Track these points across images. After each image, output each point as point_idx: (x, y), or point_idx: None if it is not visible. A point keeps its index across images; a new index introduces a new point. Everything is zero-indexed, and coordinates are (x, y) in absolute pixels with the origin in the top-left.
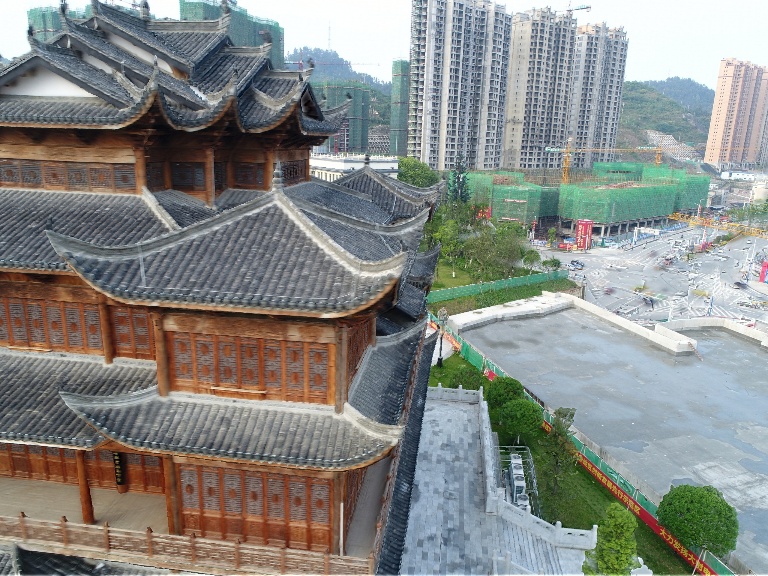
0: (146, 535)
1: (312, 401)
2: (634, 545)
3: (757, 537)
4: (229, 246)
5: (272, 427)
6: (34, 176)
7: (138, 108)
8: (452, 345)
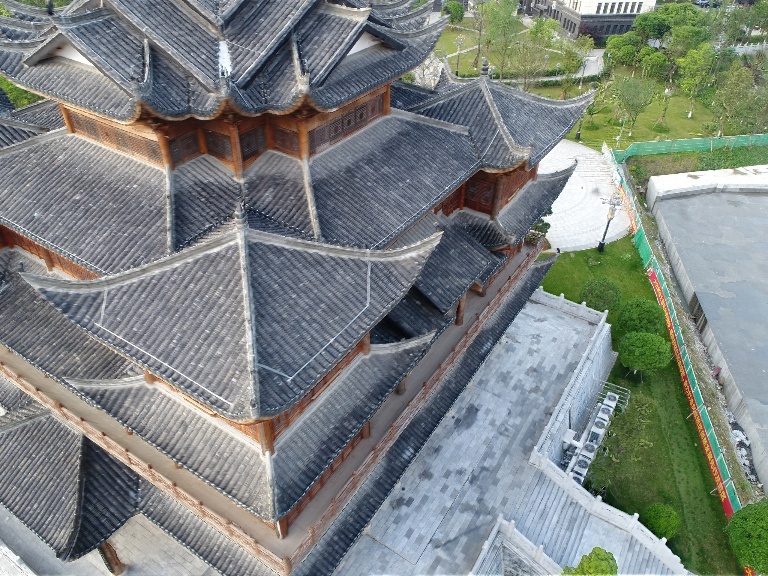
0: (148, 468)
1: (248, 434)
2: None
3: None
4: (177, 293)
5: (213, 446)
6: (94, 130)
7: (131, 113)
8: (630, 224)
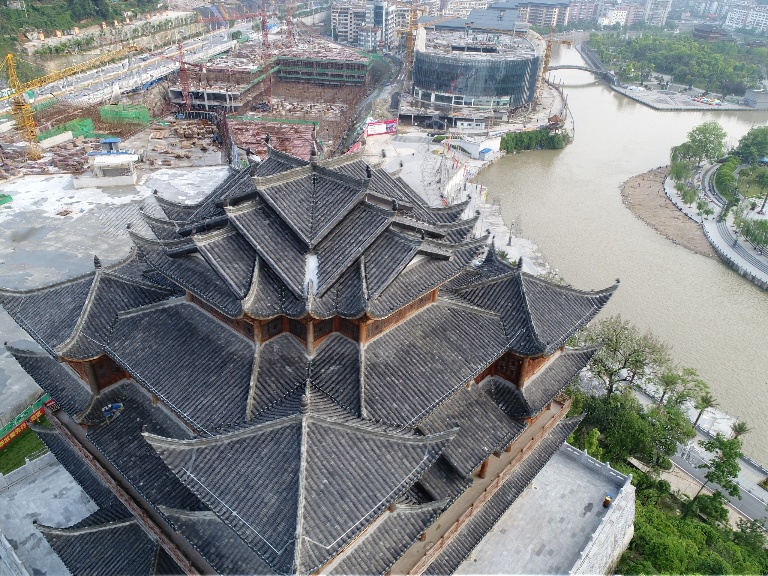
0: None
1: None
2: None
3: None
4: None
5: None
6: None
7: None
8: None
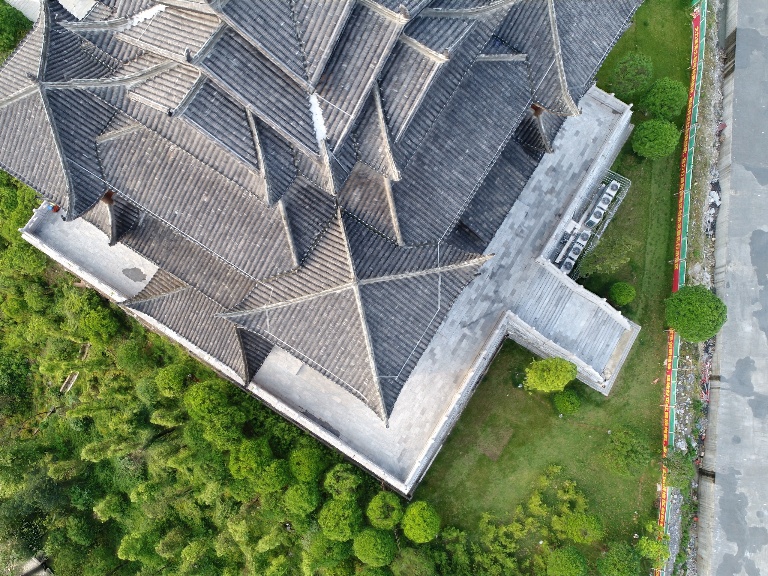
0: None
1: None
2: (565, 383)
3: (760, 311)
4: (317, 319)
5: None
6: None
7: None
8: None
